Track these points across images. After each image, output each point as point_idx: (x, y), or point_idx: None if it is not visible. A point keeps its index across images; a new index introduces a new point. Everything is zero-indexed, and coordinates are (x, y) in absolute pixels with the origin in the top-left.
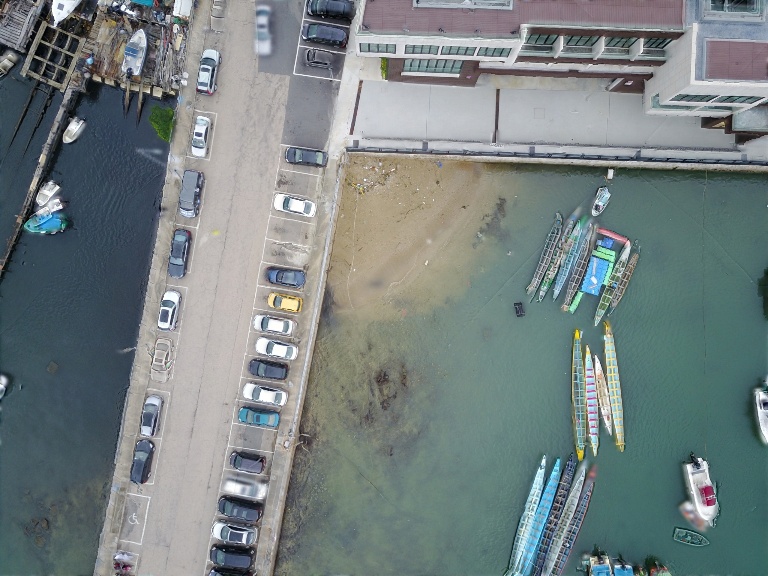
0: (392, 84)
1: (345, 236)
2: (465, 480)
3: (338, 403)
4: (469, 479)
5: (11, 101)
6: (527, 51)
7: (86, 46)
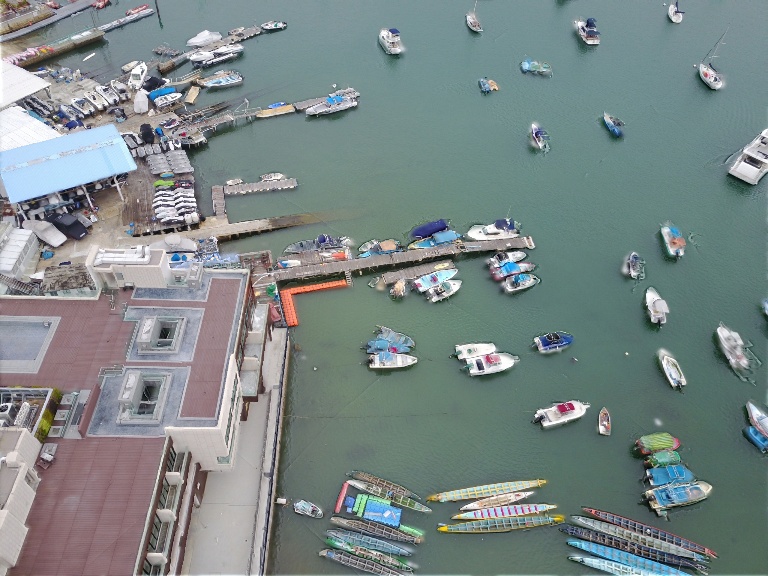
0: None
1: None
2: None
3: None
4: None
5: None
6: None
7: None
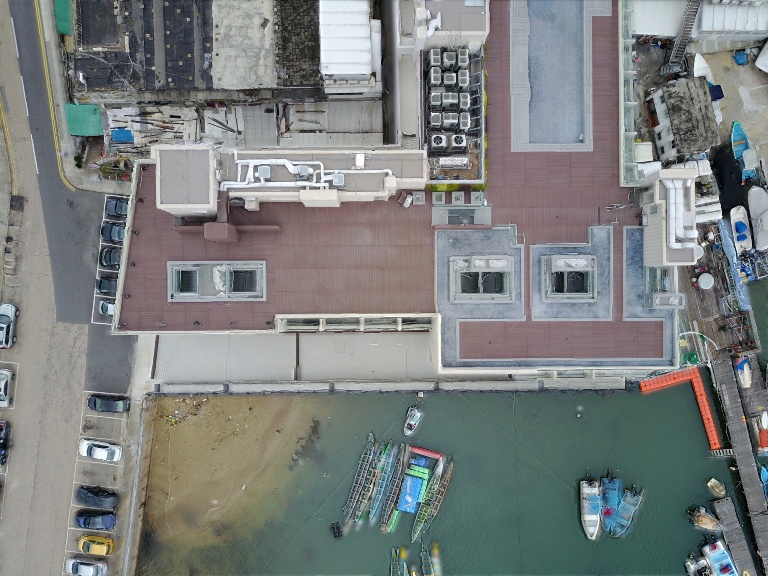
0: None
1: (160, 466)
2: None
3: None
4: None
5: None
6: (295, 324)
7: None
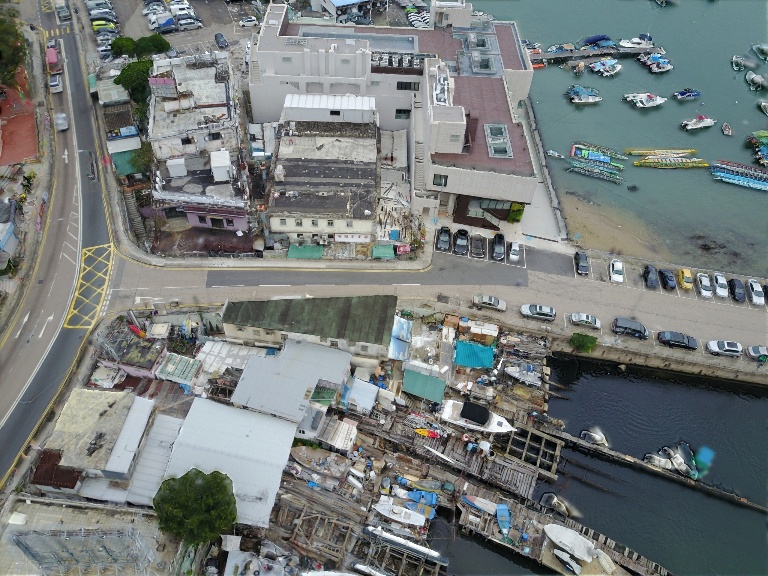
0: (520, 221)
1: None
2: (748, 213)
3: (734, 270)
4: (746, 212)
5: (581, 495)
6: None
7: (521, 421)
